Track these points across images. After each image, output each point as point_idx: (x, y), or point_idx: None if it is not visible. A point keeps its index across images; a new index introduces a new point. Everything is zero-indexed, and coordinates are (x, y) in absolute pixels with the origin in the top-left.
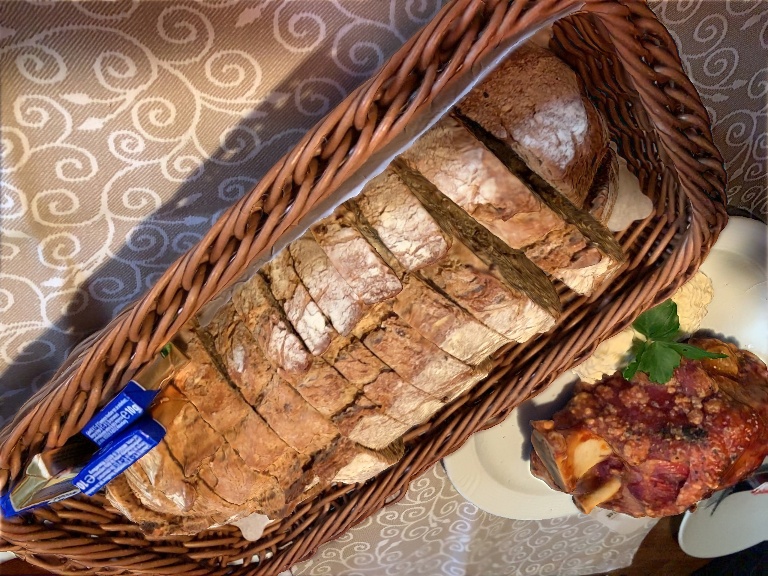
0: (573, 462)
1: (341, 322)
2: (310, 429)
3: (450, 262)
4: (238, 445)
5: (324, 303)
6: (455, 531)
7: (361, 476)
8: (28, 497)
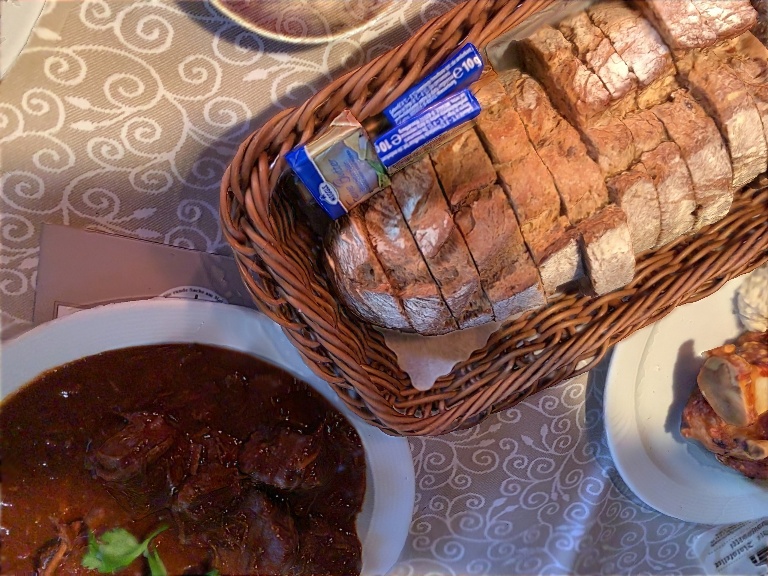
0: (755, 392)
1: (644, 71)
2: (588, 179)
3: (738, 56)
4: (513, 181)
5: (628, 56)
6: (569, 518)
7: (607, 267)
8: (328, 146)
